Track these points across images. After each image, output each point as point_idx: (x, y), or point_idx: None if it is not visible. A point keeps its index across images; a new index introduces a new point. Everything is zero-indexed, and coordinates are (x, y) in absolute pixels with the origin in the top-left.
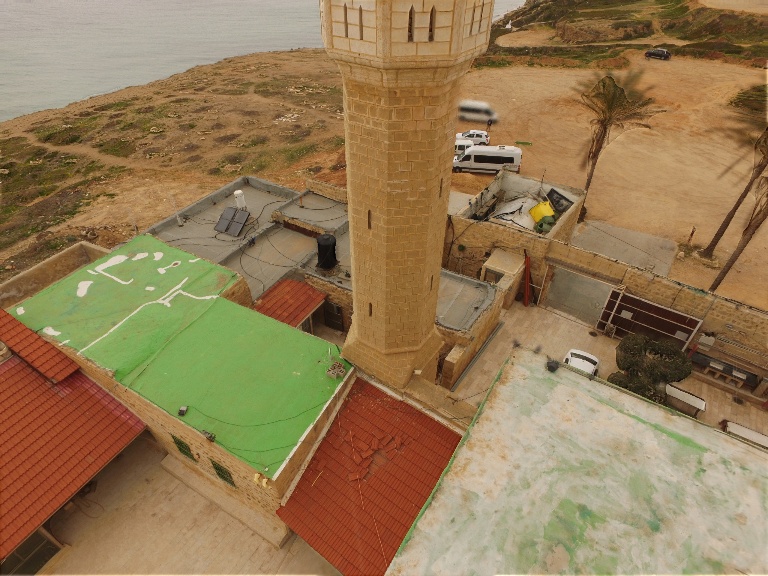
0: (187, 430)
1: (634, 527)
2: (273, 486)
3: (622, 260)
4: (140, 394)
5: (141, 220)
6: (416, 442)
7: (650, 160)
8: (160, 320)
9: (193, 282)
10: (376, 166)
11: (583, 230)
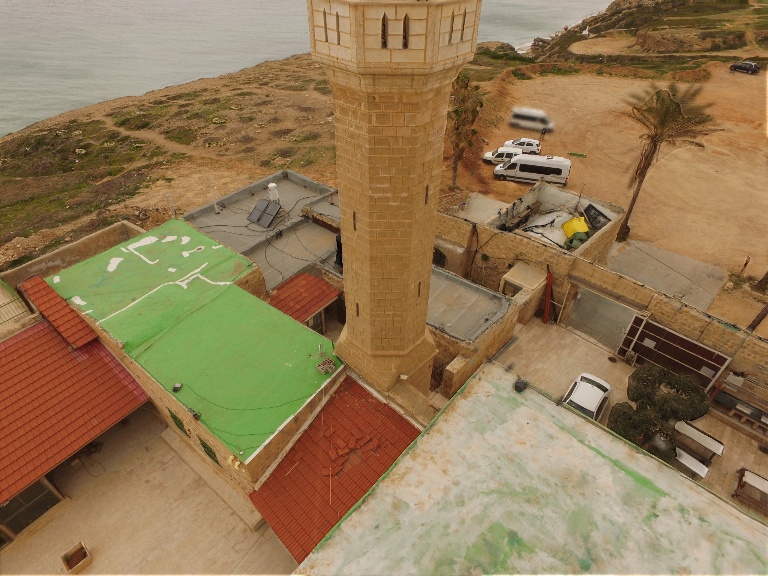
0: (178, 406)
1: (563, 562)
2: (246, 470)
3: (660, 285)
4: (143, 367)
5: (191, 205)
6: (392, 446)
7: (715, 181)
8: (174, 300)
9: (212, 267)
10: (359, 169)
11: (623, 250)
